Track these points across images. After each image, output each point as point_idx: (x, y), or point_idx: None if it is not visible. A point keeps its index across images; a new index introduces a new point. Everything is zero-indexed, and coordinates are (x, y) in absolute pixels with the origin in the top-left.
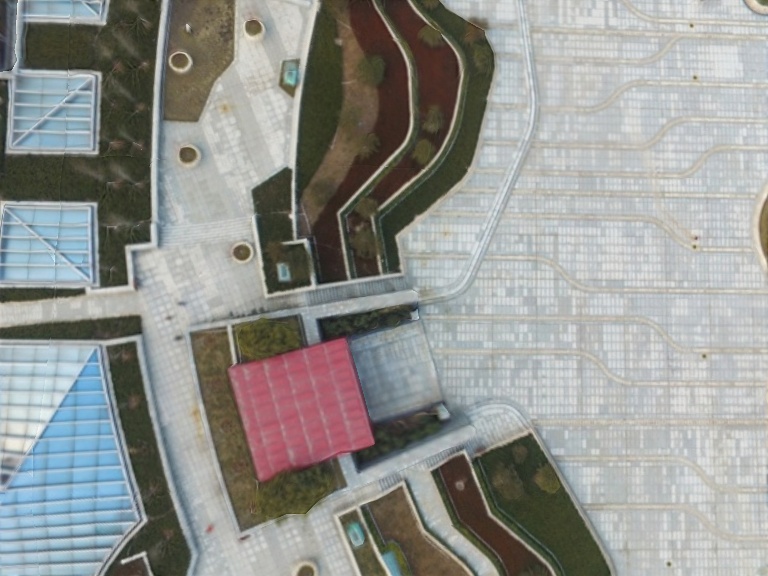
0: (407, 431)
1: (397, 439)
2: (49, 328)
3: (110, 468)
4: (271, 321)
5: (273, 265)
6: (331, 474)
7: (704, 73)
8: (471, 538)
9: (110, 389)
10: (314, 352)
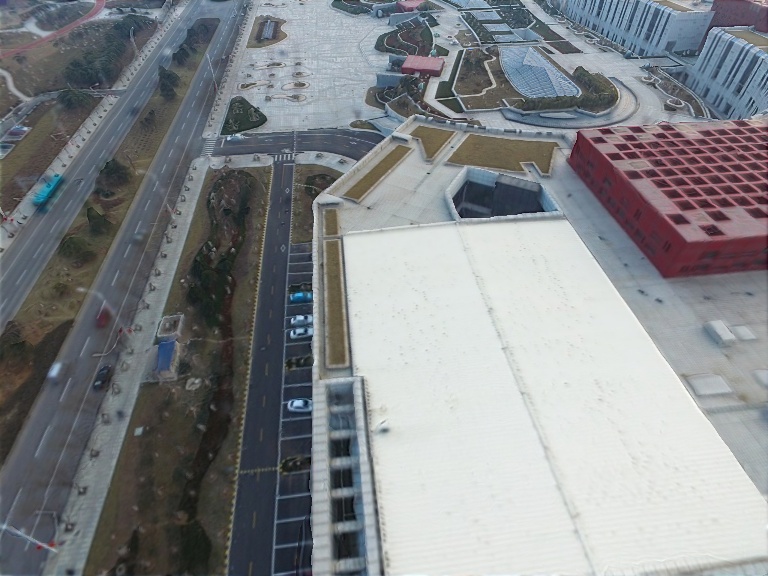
0: (388, 11)
1: (391, 8)
2: (479, 9)
3: (455, 0)
4: (426, 7)
5: (429, 14)
6: (405, 0)
7: (302, 53)
8: (369, 4)
9: (460, 5)
10: (414, 7)
